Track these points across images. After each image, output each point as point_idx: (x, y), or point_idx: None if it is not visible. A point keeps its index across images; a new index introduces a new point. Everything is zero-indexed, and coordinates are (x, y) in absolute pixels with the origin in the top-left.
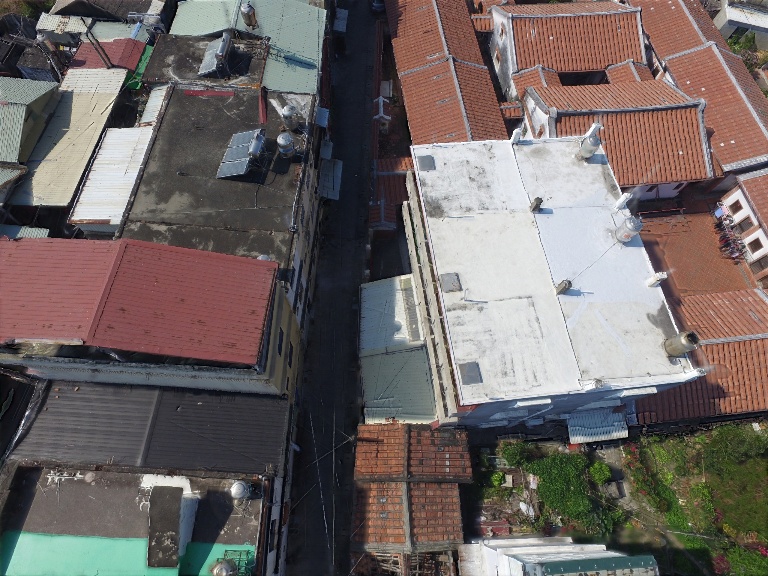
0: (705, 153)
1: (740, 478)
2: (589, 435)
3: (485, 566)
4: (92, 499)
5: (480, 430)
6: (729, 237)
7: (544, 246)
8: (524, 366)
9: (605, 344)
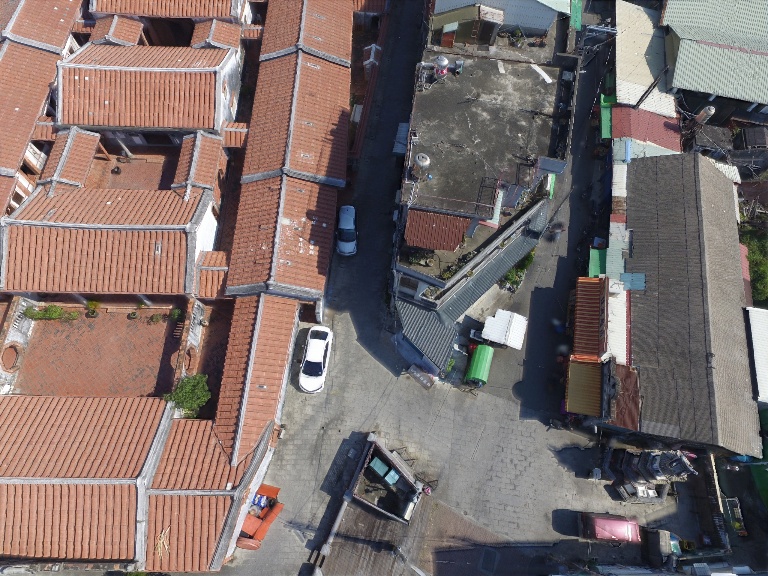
0: None
1: None
2: None
3: None
4: None
5: None
6: None
7: None
8: None
9: None
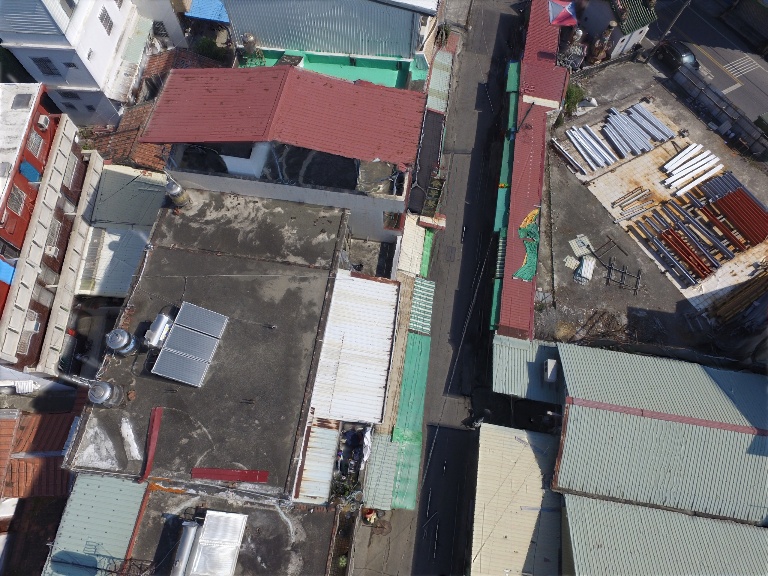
0: None
1: None
2: None
3: (105, 79)
4: None
5: None
6: None
7: None
8: None
9: None
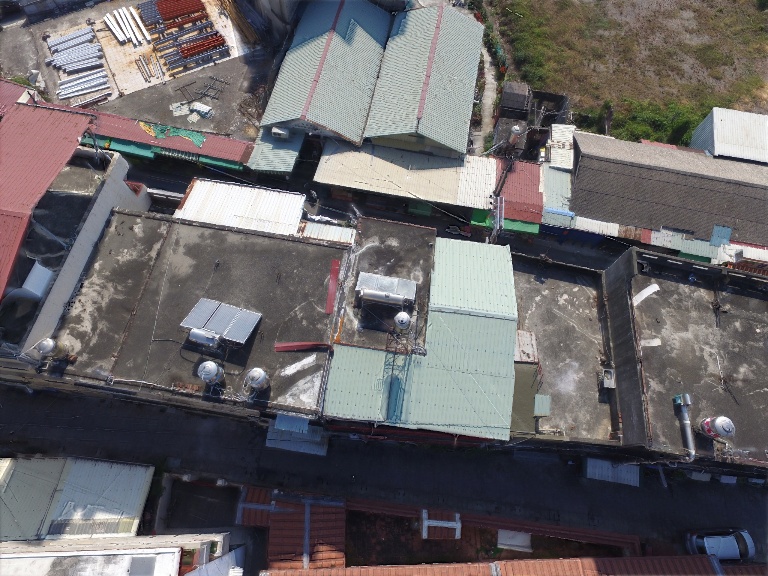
0: None
1: None
2: None
3: None
4: None
5: None
6: None
7: None
8: None
9: None
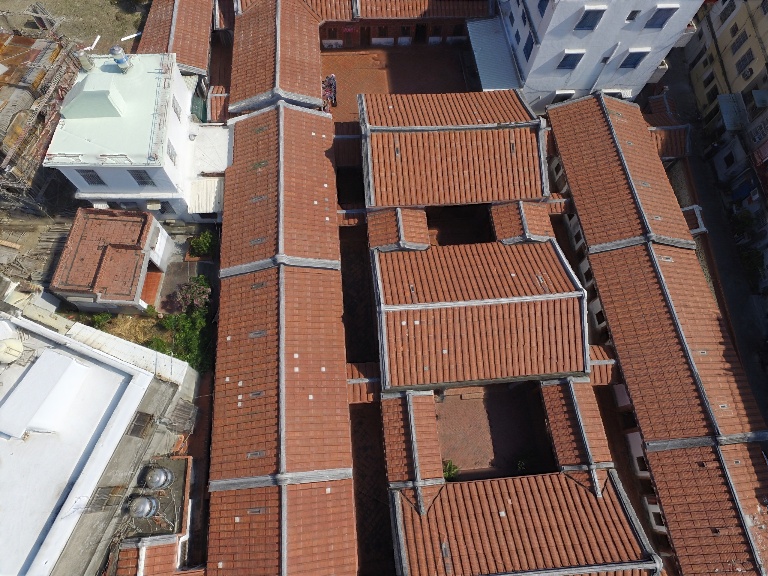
0: (365, 105)
1: None
2: None
3: None
4: None
5: None
6: None
7: None
8: None
9: None
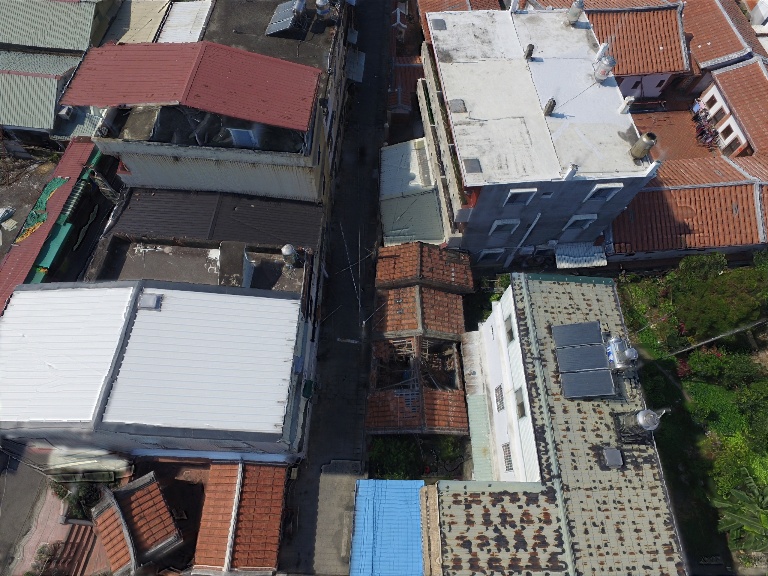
0: (683, 49)
1: (699, 291)
2: (573, 262)
3: (483, 340)
4: (170, 264)
5: (481, 269)
6: (704, 125)
7: (535, 84)
8: (516, 162)
9: (582, 150)
